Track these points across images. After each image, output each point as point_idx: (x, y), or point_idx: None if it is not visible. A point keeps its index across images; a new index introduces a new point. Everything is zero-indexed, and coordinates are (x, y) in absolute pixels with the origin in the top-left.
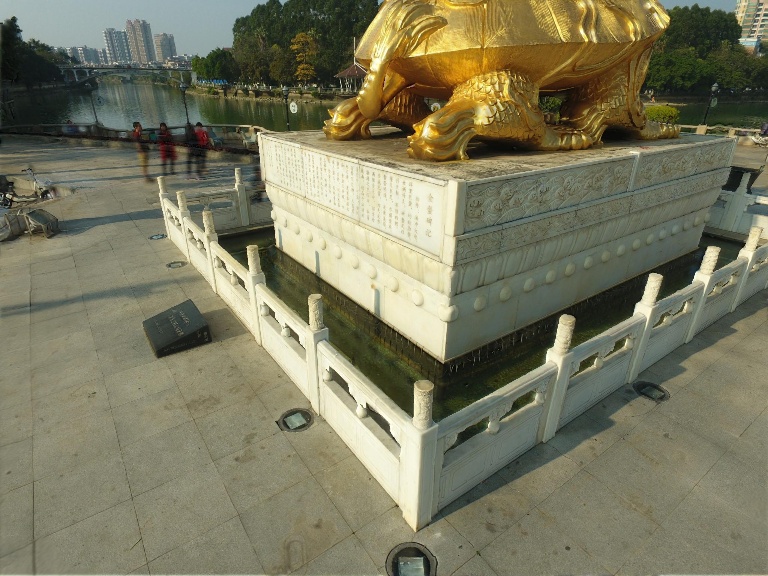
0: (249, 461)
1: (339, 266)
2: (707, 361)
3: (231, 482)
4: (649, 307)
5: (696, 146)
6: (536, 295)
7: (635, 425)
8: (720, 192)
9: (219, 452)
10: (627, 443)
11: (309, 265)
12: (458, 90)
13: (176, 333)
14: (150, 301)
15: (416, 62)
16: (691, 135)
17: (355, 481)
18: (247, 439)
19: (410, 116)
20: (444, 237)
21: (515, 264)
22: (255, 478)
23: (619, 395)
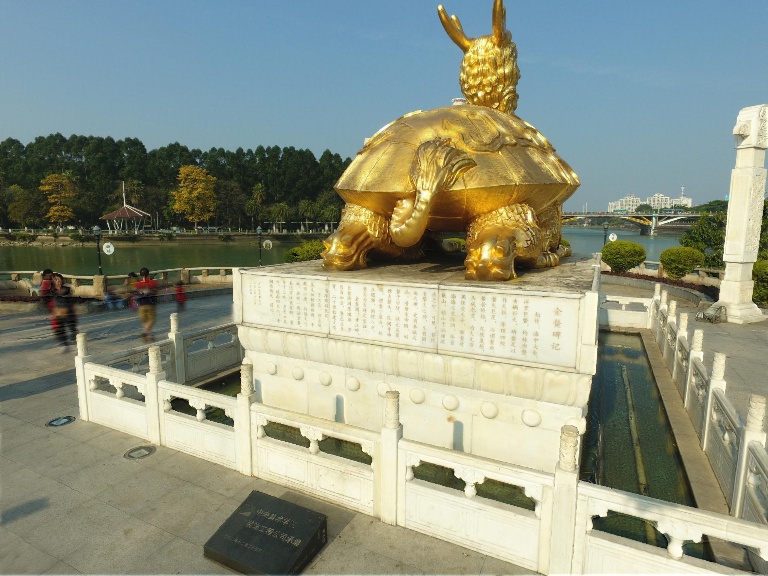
0: None
1: None
2: None
3: None
4: (723, 381)
5: None
6: None
7: None
8: None
9: None
10: None
11: (321, 414)
12: (485, 219)
13: (288, 544)
14: (163, 513)
15: (454, 195)
16: None
17: None
18: None
19: None
20: (581, 347)
21: None
22: None
23: None
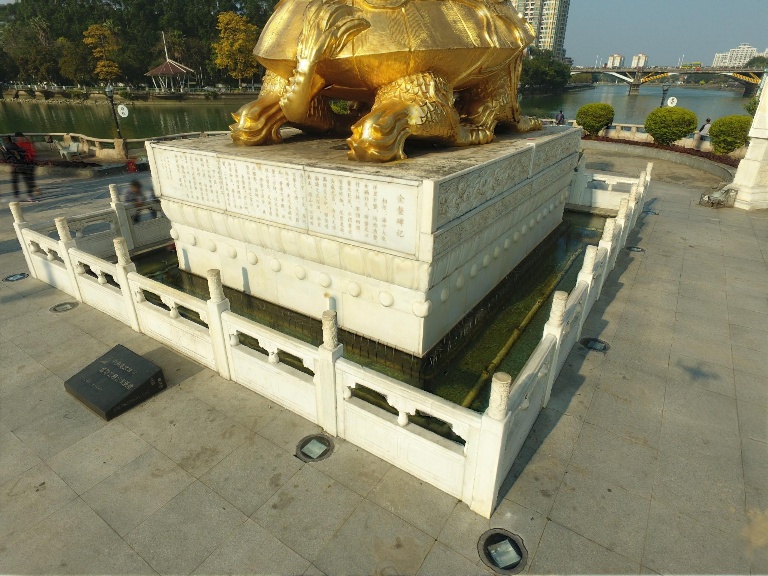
0: (290, 504)
1: (278, 280)
2: (618, 312)
3: (283, 532)
4: (590, 274)
5: (562, 136)
6: (477, 279)
7: (599, 375)
8: (573, 173)
9: (250, 505)
10: (602, 391)
11: (233, 284)
12: (384, 91)
13: (122, 387)
14: (54, 356)
15: (343, 63)
16: (548, 127)
17: (409, 490)
18: (273, 482)
19: (319, 118)
20: (420, 235)
21: (467, 253)
22: (307, 520)
23: (575, 353)
